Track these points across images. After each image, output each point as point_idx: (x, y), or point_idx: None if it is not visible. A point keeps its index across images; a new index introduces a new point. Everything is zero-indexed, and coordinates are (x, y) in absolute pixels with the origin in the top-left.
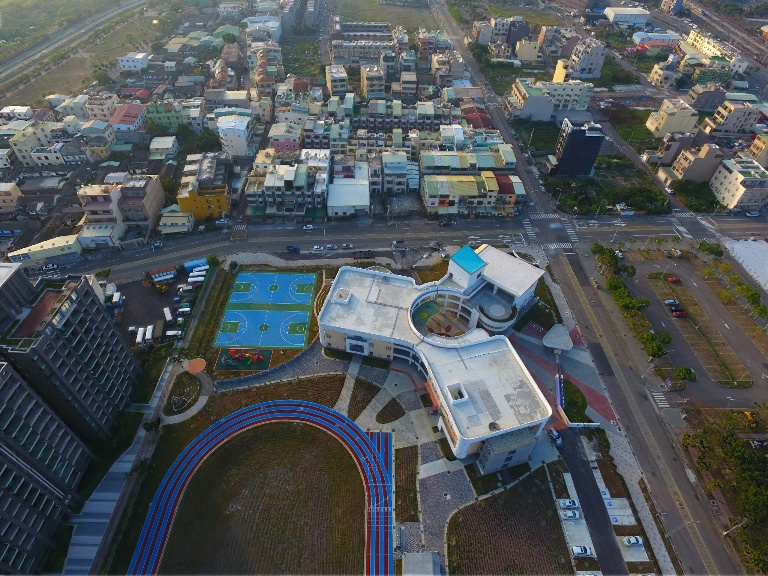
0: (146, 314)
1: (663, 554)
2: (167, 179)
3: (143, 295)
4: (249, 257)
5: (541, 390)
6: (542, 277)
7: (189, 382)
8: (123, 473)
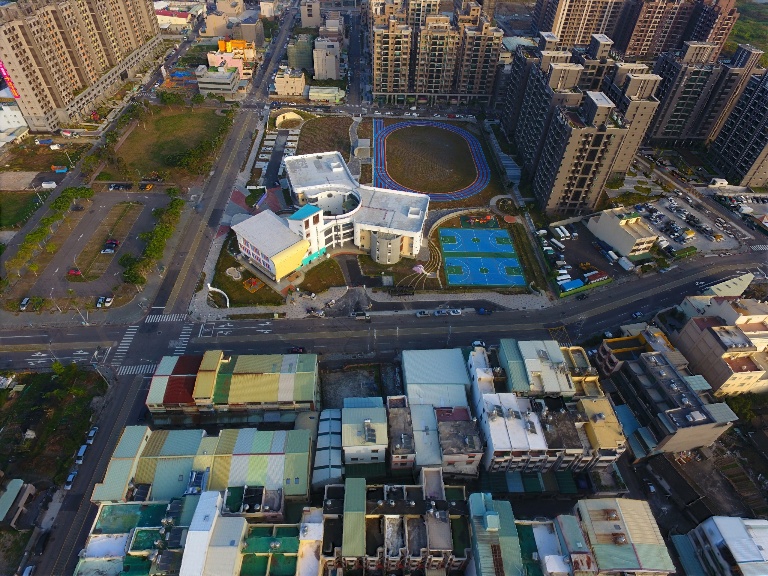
0: (578, 251)
1: (252, 155)
2: (733, 401)
3: (597, 265)
4: (528, 303)
5: (272, 203)
6: (215, 275)
7: (508, 211)
8: (513, 180)
